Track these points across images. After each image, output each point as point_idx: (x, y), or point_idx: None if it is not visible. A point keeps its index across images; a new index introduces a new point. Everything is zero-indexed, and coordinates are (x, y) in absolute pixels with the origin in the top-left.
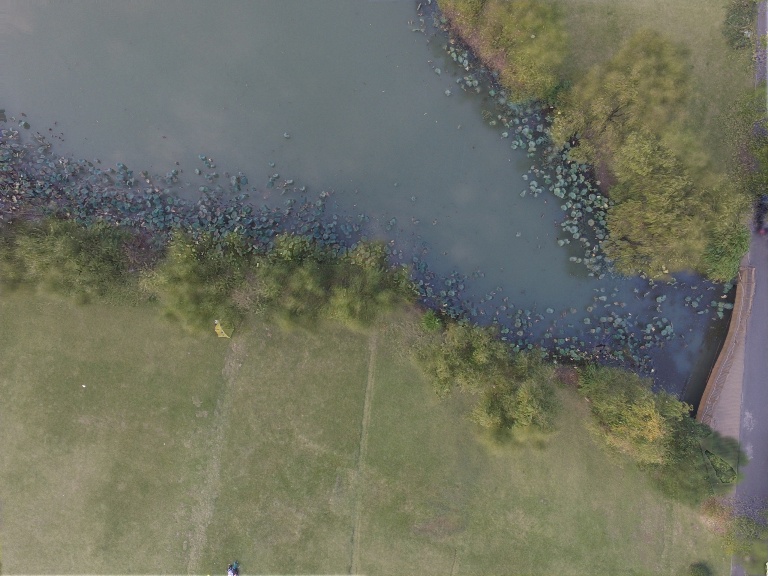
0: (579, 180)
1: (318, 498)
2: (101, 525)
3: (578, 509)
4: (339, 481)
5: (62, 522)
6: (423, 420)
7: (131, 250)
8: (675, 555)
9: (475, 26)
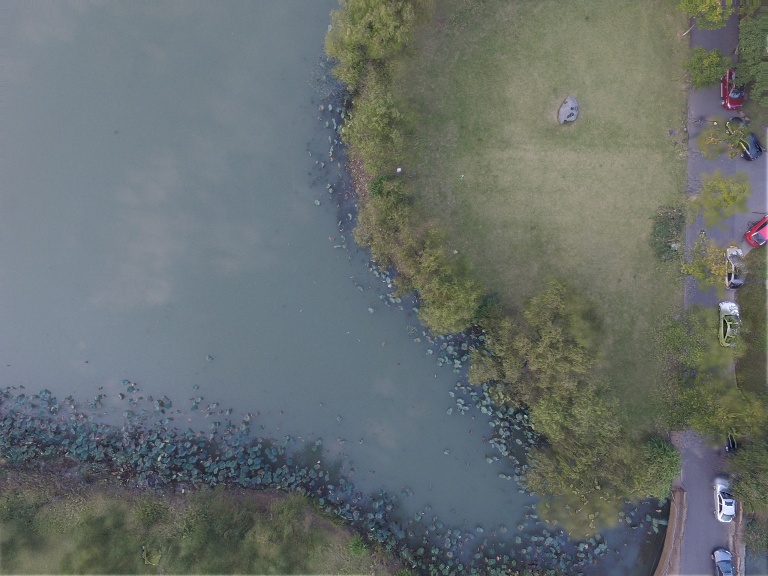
0: (506, 398)
1: None
2: None
3: None
4: None
5: None
6: None
7: (58, 476)
8: None
9: (397, 241)
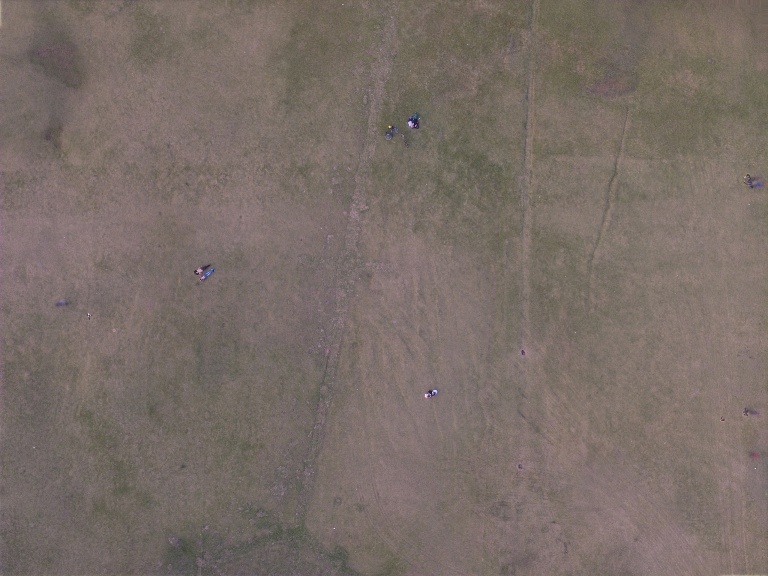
0: None
1: (493, 57)
2: (282, 81)
3: (744, 69)
4: (513, 42)
5: (244, 78)
6: None
7: None
8: None
9: None
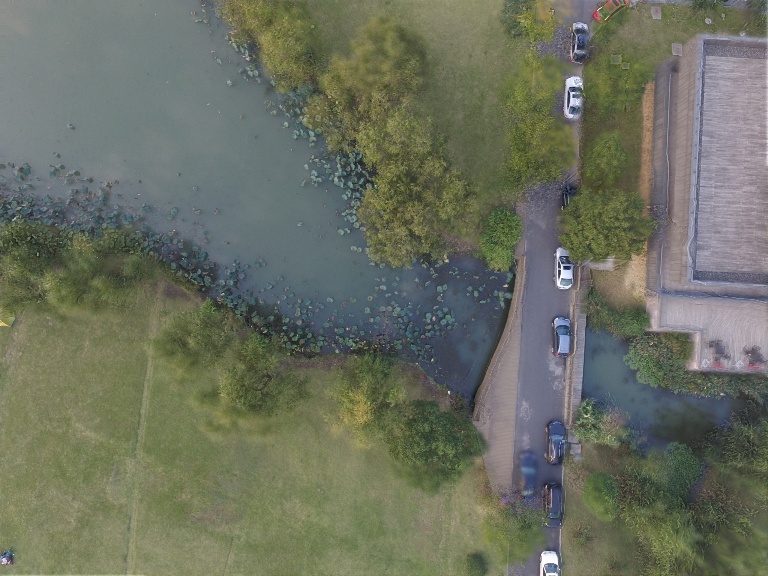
0: (357, 169)
1: (95, 486)
2: None
3: (355, 498)
4: (117, 469)
5: None
6: (202, 409)
7: None
8: (452, 545)
9: (257, 16)
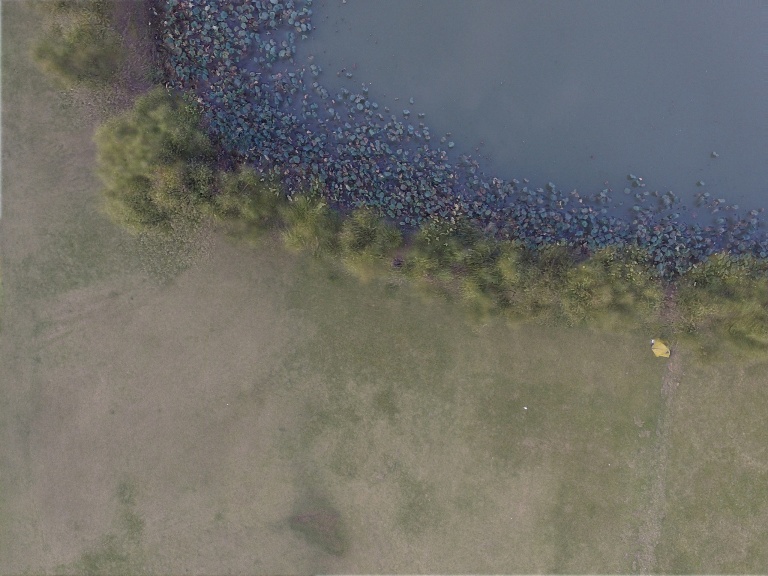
0: None
1: (761, 515)
2: (550, 547)
3: None
4: None
5: (511, 545)
6: None
7: (564, 270)
8: None
9: None
